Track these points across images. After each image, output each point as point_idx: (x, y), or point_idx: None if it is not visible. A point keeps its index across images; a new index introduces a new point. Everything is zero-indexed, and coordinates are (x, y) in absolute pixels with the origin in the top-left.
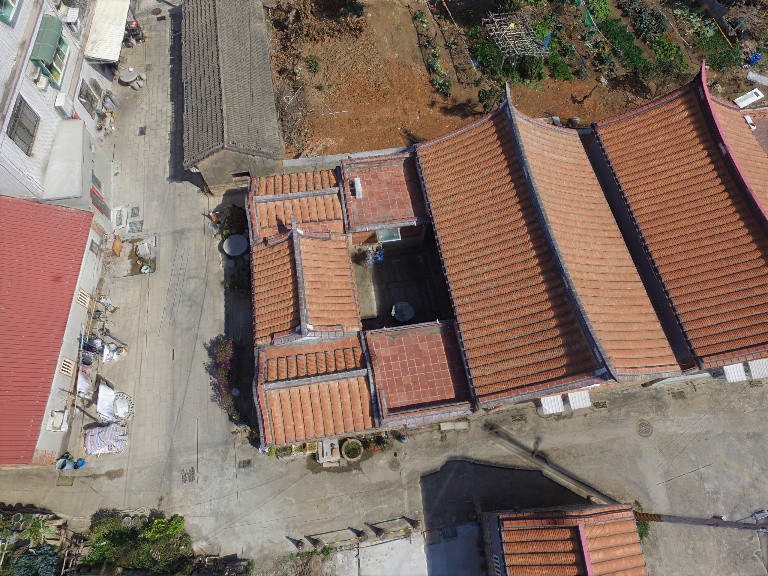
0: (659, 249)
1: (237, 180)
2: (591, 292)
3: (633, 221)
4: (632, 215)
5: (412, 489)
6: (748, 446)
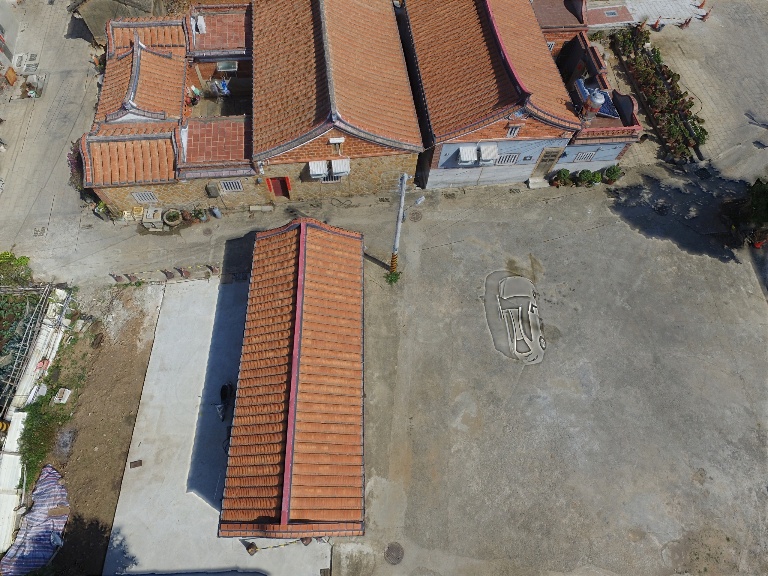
0: (426, 67)
1: None
2: (355, 84)
3: (413, 51)
4: (413, 46)
5: (218, 248)
6: (496, 231)
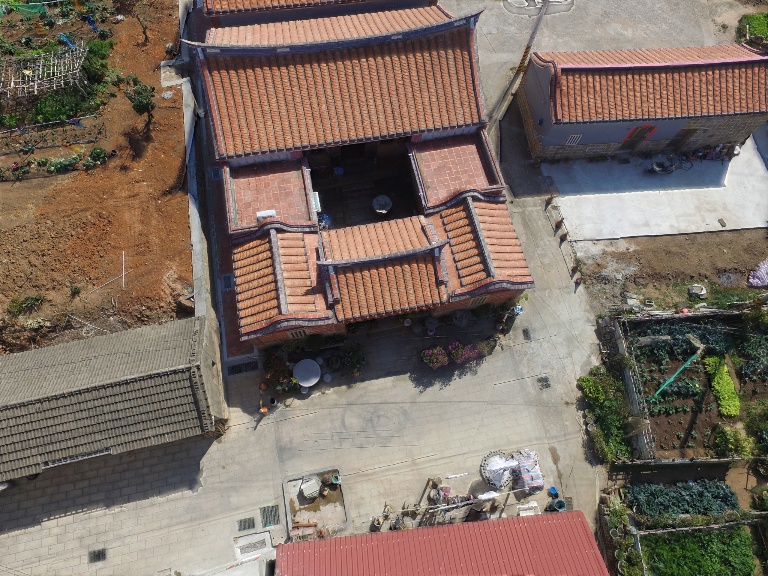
0: None
1: (217, 381)
2: None
3: (317, 5)
4: (312, 4)
5: (525, 204)
6: (465, 6)
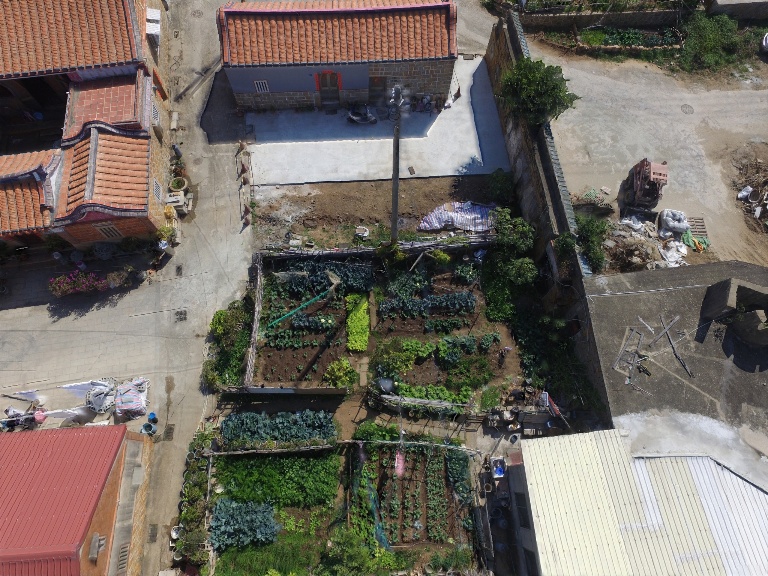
0: None
1: None
2: None
3: None
4: None
5: (217, 150)
6: None
